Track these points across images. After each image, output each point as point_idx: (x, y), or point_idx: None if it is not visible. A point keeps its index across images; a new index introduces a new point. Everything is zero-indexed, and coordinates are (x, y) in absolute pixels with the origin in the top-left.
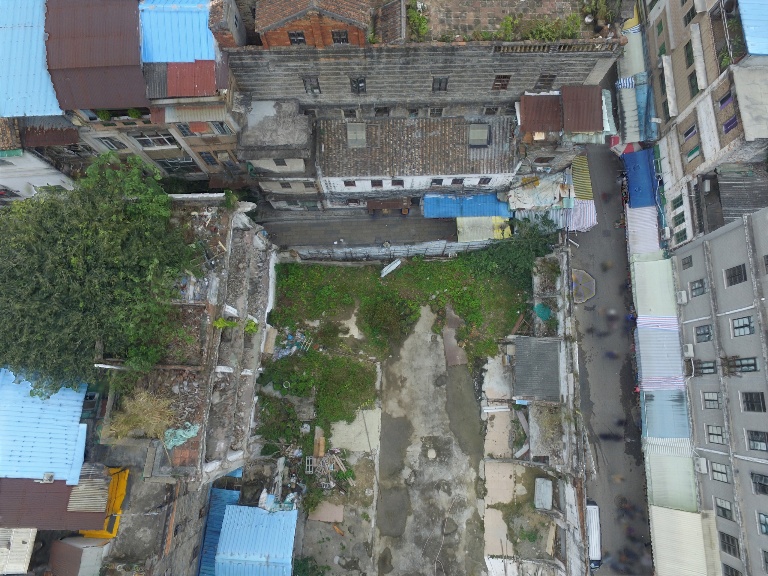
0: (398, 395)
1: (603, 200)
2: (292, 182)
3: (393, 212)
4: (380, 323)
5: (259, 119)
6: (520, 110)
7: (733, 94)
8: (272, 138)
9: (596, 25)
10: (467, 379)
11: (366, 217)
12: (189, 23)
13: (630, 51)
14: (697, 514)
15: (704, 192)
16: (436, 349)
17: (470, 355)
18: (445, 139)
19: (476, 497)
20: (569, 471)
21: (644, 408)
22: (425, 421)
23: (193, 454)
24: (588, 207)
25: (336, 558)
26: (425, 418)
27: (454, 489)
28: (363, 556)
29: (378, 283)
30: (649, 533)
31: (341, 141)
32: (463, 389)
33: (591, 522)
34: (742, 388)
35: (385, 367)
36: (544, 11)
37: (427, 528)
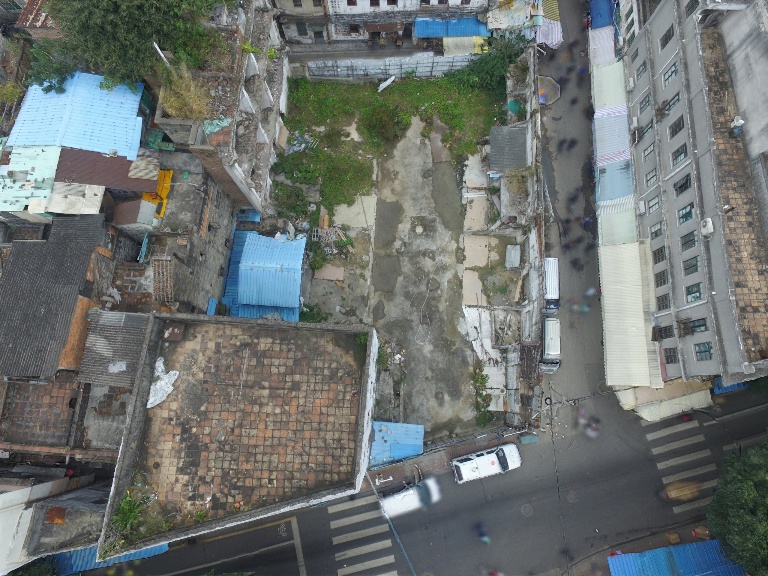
0: (391, 185)
1: (571, 34)
2: None
3: (389, 45)
4: (376, 124)
5: None
6: None
7: None
8: None
9: None
10: (450, 173)
11: (366, 49)
12: None
13: None
14: (636, 242)
15: None
16: (424, 150)
17: (453, 154)
18: None
19: (456, 262)
20: (531, 214)
21: (598, 180)
22: (414, 205)
23: (226, 138)
24: (555, 27)
25: (337, 307)
26: (414, 202)
27: (438, 256)
28: (360, 306)
29: (375, 97)
30: (598, 269)
31: None
32: (447, 180)
33: (551, 269)
34: (669, 123)
35: (380, 163)
36: None
37: (414, 285)
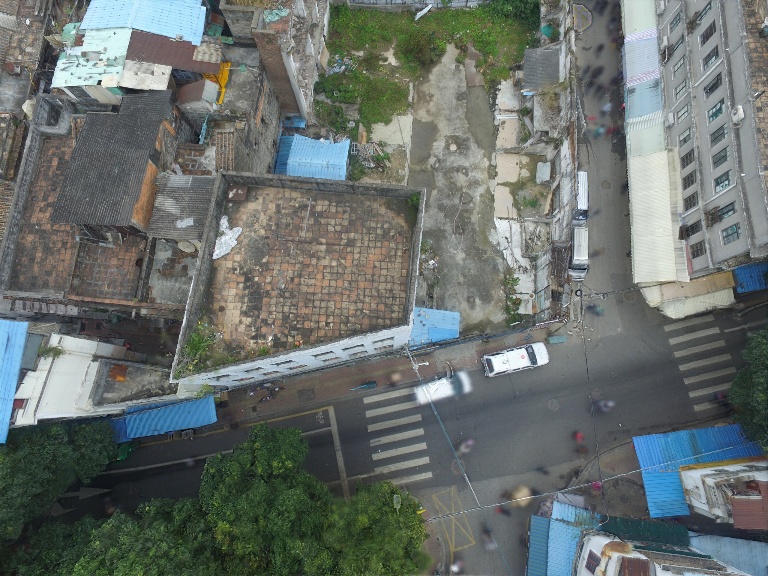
0: (427, 106)
1: None
2: None
3: None
4: (414, 48)
5: None
6: None
7: None
8: None
9: None
10: (484, 96)
11: None
12: None
13: None
14: (664, 151)
15: None
16: (459, 74)
17: (487, 79)
18: None
19: (488, 178)
20: (564, 124)
21: (627, 100)
22: (448, 125)
23: (285, 27)
24: None
25: None
26: (448, 123)
27: (471, 172)
28: None
29: (412, 25)
30: (627, 179)
31: None
32: (480, 103)
33: (581, 181)
34: (701, 32)
35: (417, 86)
36: None
37: (448, 198)
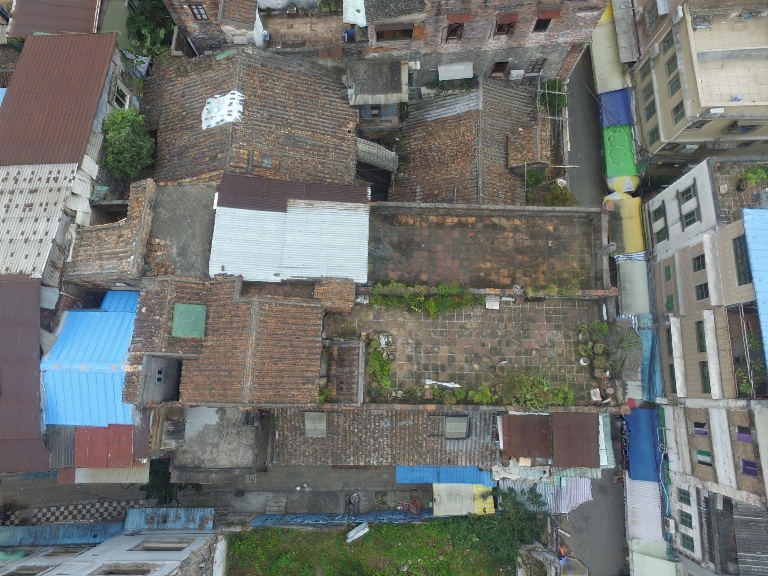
0: None
1: None
2: None
3: None
4: None
5: (198, 428)
6: (503, 430)
7: (754, 441)
8: (212, 455)
9: (593, 373)
10: None
11: None
12: (101, 385)
13: (633, 282)
14: None
15: (716, 509)
16: None
17: None
18: (418, 429)
19: None
20: None
21: None
22: None
23: None
24: (582, 478)
25: None
26: None
27: None
28: None
29: (343, 549)
30: None
31: (298, 429)
32: None
33: None
34: None
35: None
36: (532, 345)
37: None
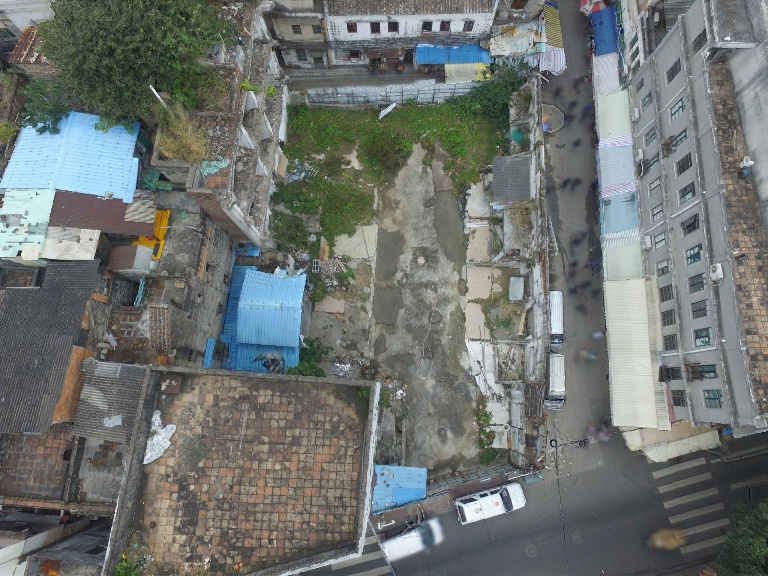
0: (393, 214)
1: (574, 59)
2: (302, 25)
3: (390, 70)
4: (377, 152)
5: None
6: None
7: None
8: None
9: None
10: (452, 202)
11: (366, 74)
12: None
13: None
14: (642, 279)
15: (654, 23)
16: (426, 178)
17: (455, 182)
18: None
19: (459, 294)
20: (535, 249)
21: (603, 212)
22: (416, 235)
23: (224, 180)
24: (559, 54)
25: (338, 341)
26: (416, 232)
27: (440, 288)
28: (361, 339)
29: (376, 124)
30: None
31: None
32: (449, 210)
33: (555, 303)
34: (676, 159)
35: (381, 192)
36: None
37: (416, 318)
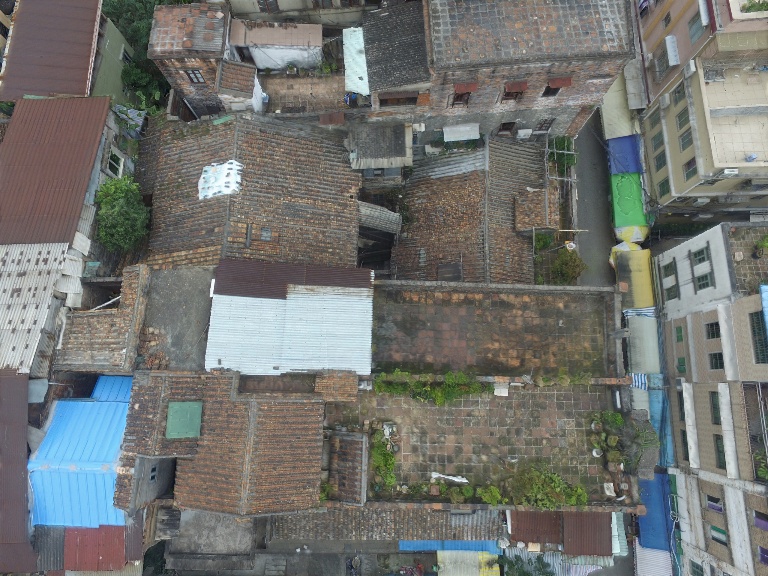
0: None
1: None
2: None
3: None
4: None
5: None
6: (511, 514)
7: None
8: (209, 540)
9: (606, 466)
10: None
11: None
12: (92, 485)
13: (643, 339)
14: None
15: None
16: None
17: None
18: None
19: None
20: None
21: None
22: None
23: None
24: None
25: None
26: None
27: None
28: None
29: None
30: None
31: None
32: None
33: None
34: None
35: None
36: (542, 434)
37: None
